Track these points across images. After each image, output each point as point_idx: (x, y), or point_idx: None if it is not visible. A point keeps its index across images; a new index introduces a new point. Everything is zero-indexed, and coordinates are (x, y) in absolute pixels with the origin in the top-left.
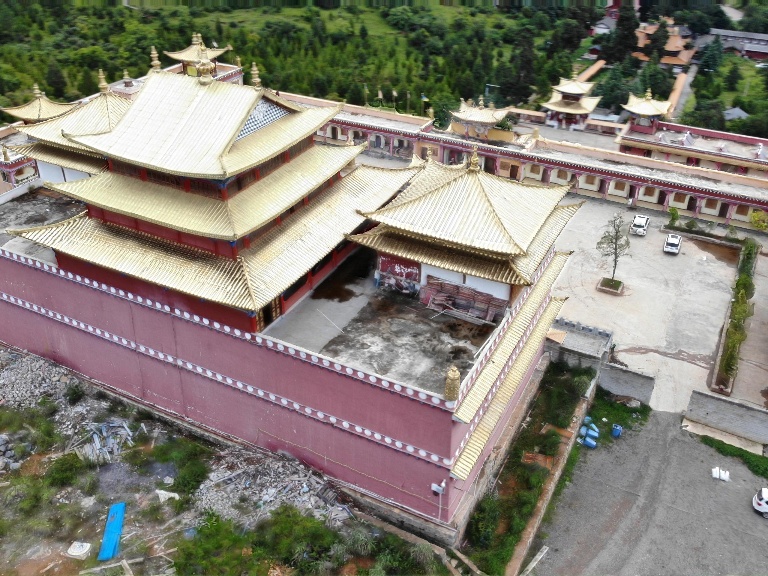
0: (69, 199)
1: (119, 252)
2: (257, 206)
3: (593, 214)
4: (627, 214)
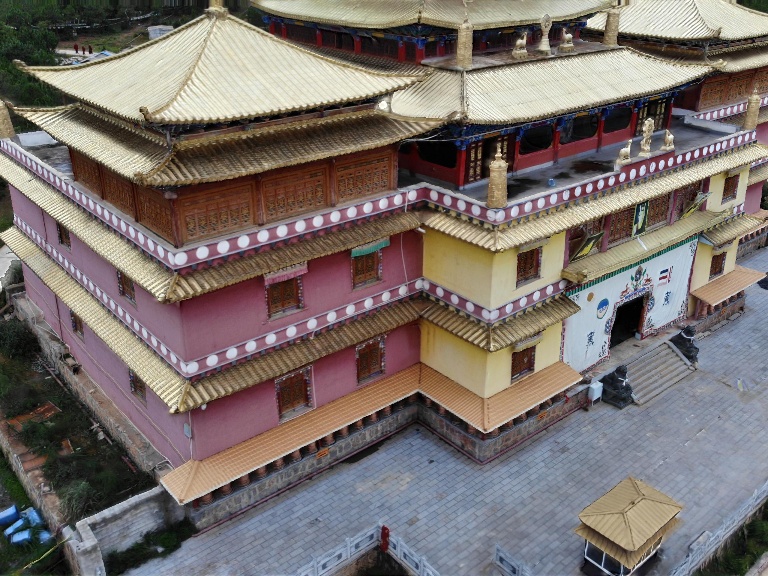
0: None
1: None
2: (298, 1)
3: None
4: None
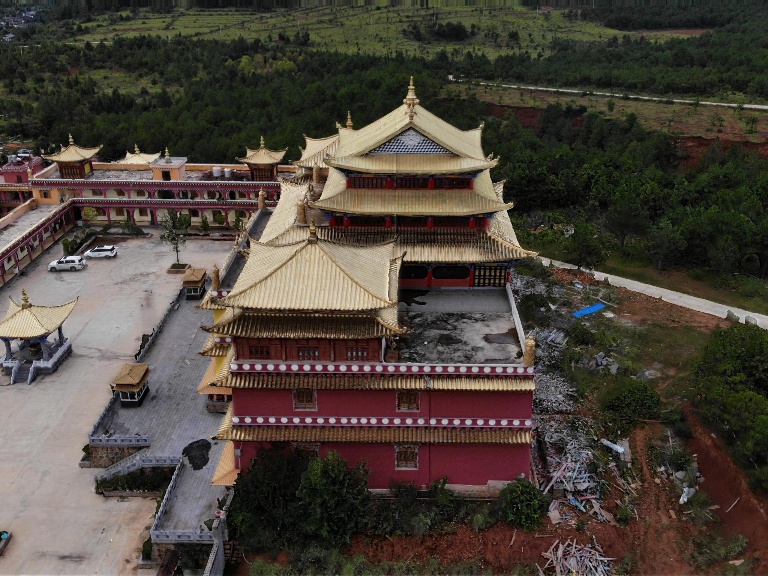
0: (394, 342)
1: (502, 223)
2: None
3: (37, 287)
4: (34, 276)
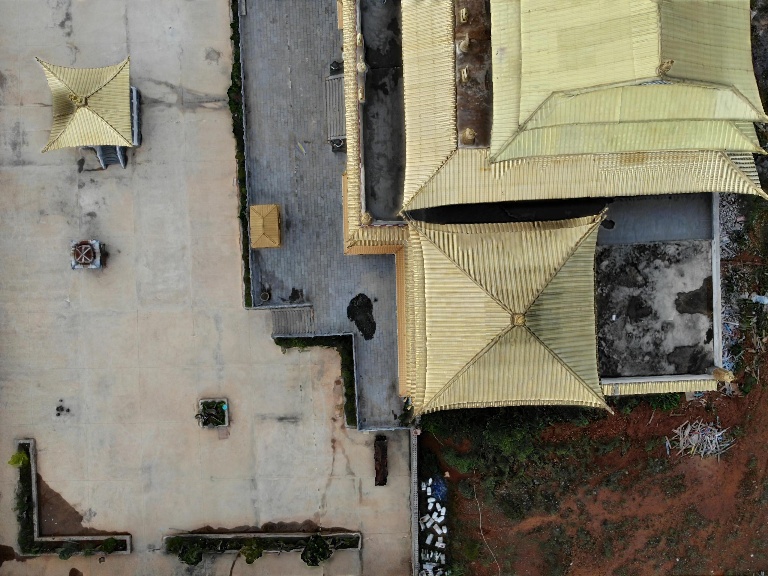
0: None
1: None
2: None
3: None
4: None
